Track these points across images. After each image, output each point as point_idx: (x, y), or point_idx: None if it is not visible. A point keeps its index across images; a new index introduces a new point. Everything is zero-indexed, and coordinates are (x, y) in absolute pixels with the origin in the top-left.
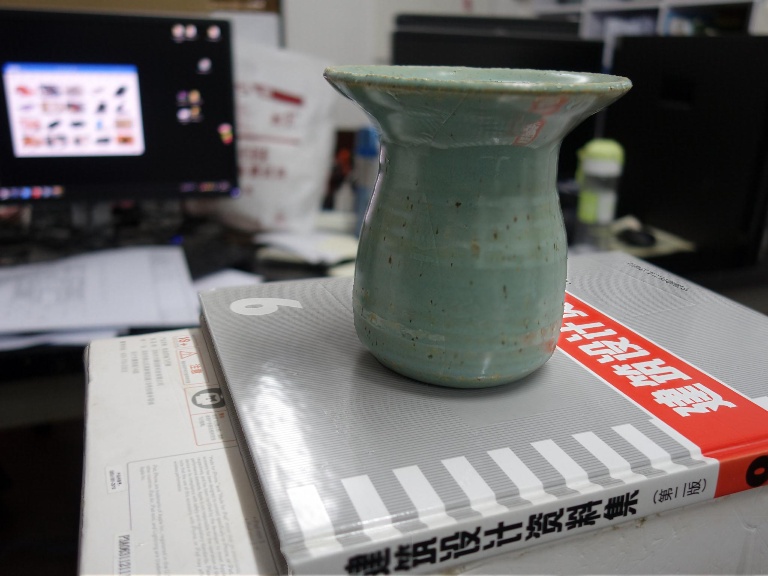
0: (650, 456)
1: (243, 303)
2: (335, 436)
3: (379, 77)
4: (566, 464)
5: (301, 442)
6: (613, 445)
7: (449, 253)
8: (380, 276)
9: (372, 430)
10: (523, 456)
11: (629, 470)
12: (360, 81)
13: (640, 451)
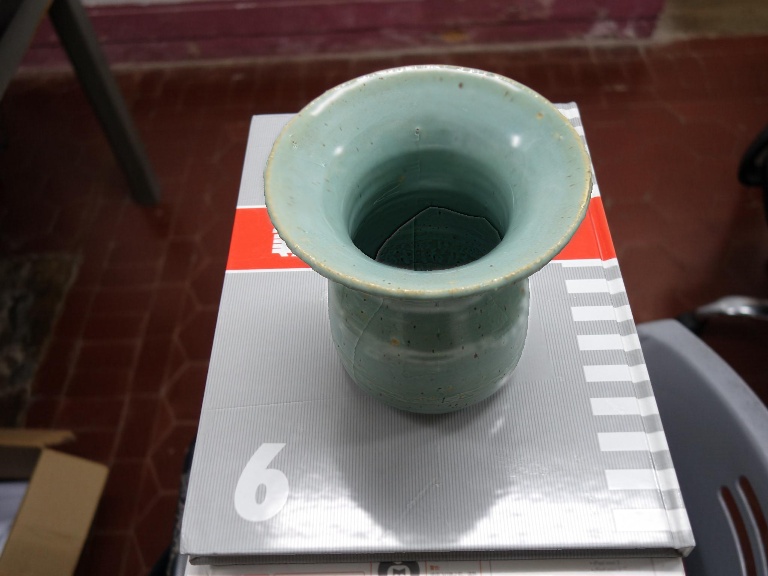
0: (606, 290)
1: (247, 505)
2: (551, 478)
3: (522, 272)
4: (609, 341)
5: (556, 506)
6: (590, 303)
7: (515, 312)
8: (467, 371)
9: (546, 448)
10: (596, 362)
11: (614, 309)
12: (501, 287)
13: (599, 292)
